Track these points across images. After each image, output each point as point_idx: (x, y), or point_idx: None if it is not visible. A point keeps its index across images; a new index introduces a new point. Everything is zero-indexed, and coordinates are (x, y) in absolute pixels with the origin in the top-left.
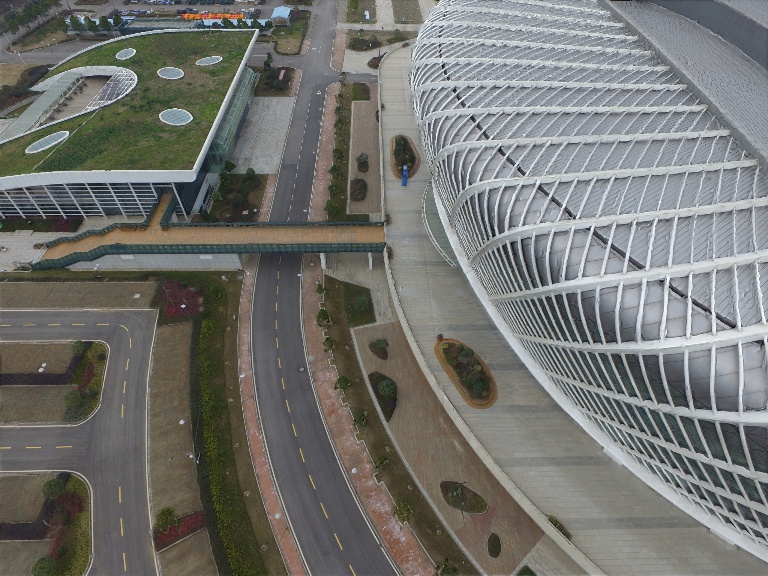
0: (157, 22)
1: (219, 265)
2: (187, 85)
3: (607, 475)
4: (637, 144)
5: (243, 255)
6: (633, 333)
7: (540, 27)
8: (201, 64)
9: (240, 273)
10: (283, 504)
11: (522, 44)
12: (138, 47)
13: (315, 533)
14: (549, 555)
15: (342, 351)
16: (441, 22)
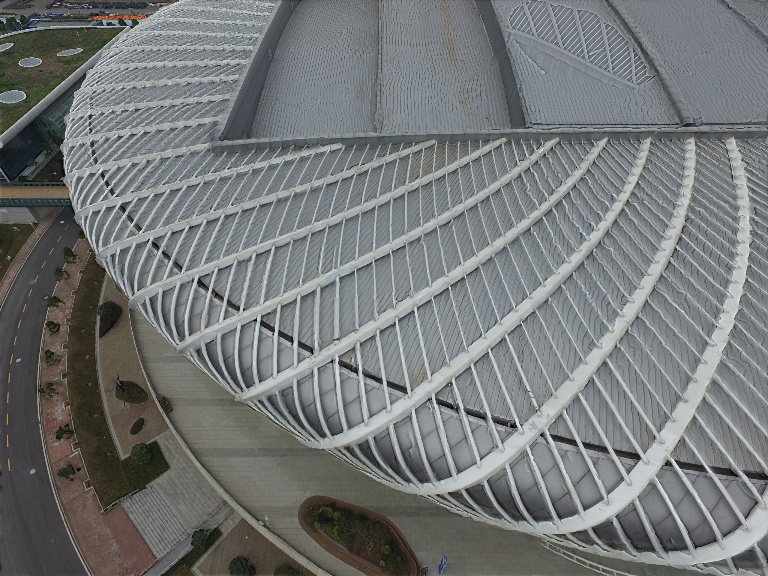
0: (60, 22)
1: (16, 218)
2: (38, 72)
3: None
4: (172, 86)
5: (41, 211)
6: None
7: (218, 8)
8: (61, 55)
9: (34, 225)
10: None
11: (188, 20)
12: (17, 41)
13: None
14: None
15: (89, 285)
16: (165, 7)
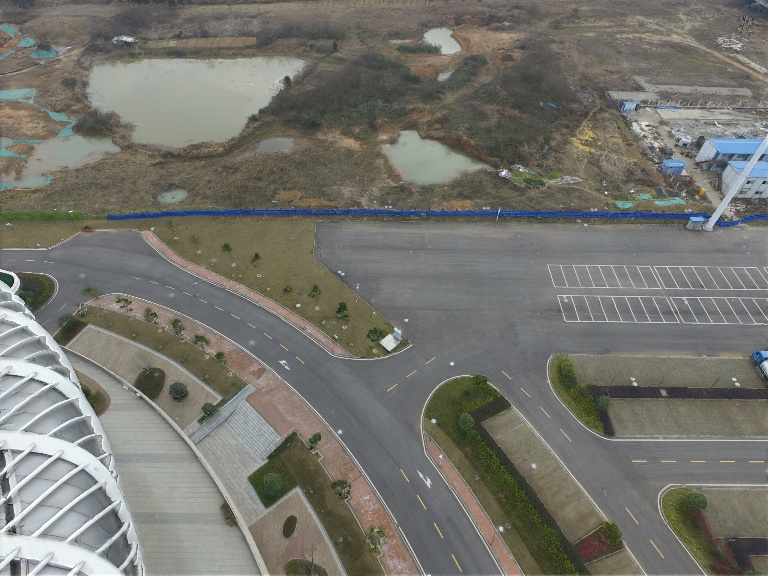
0: None
1: None
2: None
3: (147, 571)
4: None
5: None
6: (103, 490)
7: None
8: None
9: None
10: (502, 572)
11: None
12: None
13: (462, 539)
14: (242, 516)
15: None
16: None
